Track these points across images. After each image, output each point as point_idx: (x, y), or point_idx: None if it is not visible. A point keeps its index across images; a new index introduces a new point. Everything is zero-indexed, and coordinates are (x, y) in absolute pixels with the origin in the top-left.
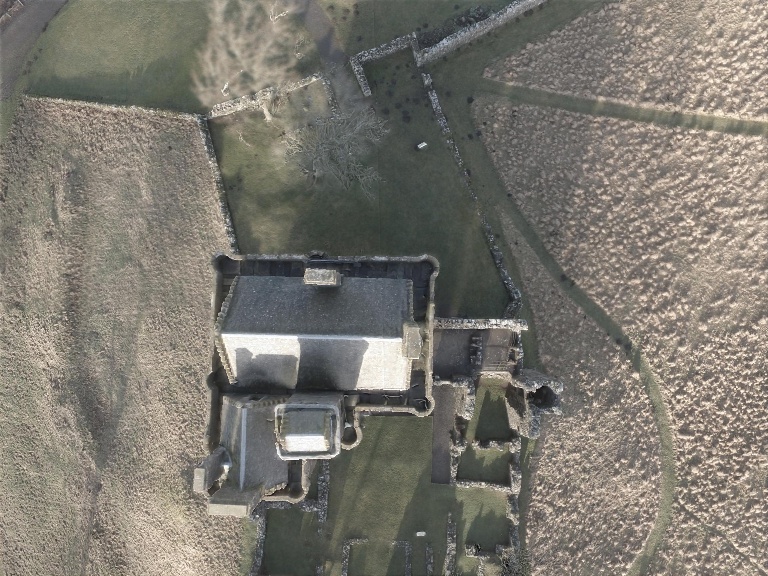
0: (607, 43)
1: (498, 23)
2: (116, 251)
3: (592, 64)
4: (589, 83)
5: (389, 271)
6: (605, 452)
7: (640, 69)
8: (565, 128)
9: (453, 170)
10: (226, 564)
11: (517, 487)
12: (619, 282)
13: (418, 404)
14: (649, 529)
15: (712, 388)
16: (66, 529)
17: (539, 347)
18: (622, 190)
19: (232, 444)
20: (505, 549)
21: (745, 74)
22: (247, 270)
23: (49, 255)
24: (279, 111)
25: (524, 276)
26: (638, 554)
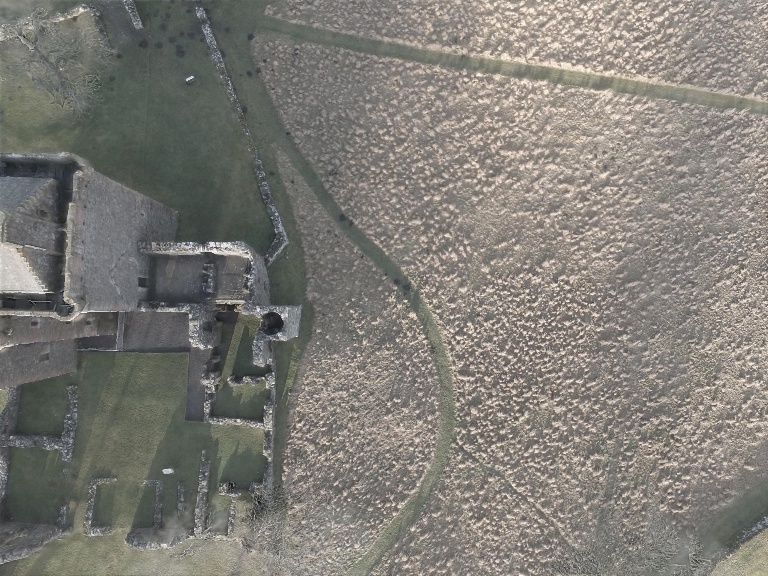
0: None
1: None
2: None
3: (378, 5)
4: (375, 24)
5: (38, 172)
6: (376, 391)
7: (427, 11)
8: (349, 68)
9: (225, 106)
10: None
11: (268, 422)
12: (399, 222)
13: (66, 310)
14: (424, 469)
15: (494, 329)
16: None
17: (308, 285)
18: (405, 131)
19: None
20: (257, 486)
21: (533, 19)
22: None
23: None
24: None
25: (298, 214)
26: (412, 494)
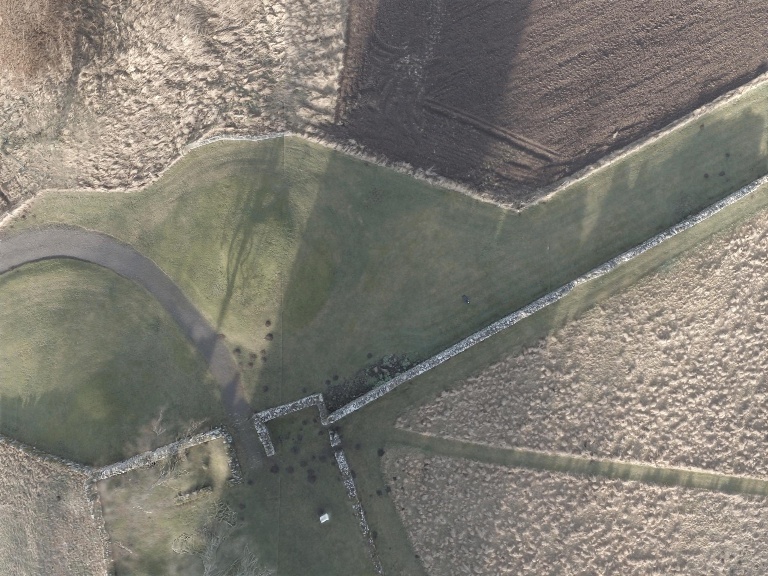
0: (525, 388)
1: None
2: None
3: (509, 411)
4: (505, 432)
5: None
6: None
7: (558, 416)
8: (478, 480)
9: (357, 539)
10: None
11: None
12: None
13: None
14: None
15: None
16: None
17: None
18: (534, 547)
19: None
20: None
21: (664, 420)
22: None
23: None
24: (176, 469)
25: None
26: None
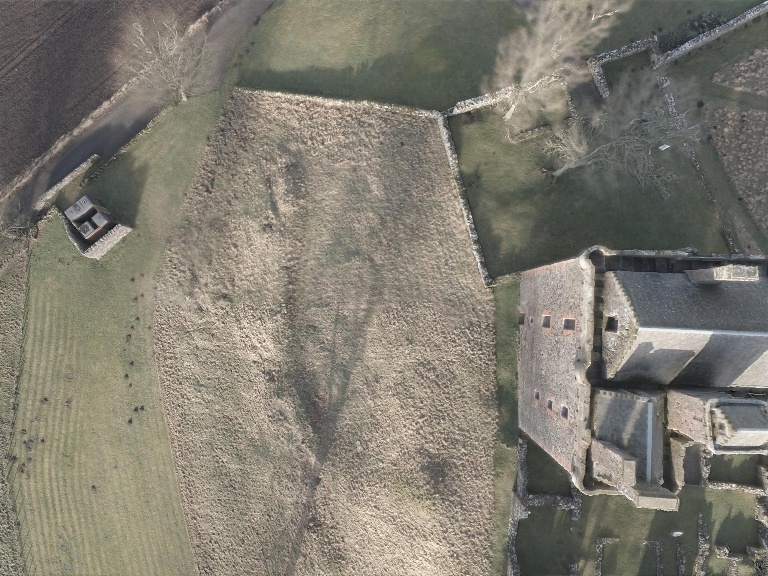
0: None
1: (730, 29)
2: (339, 245)
3: None
4: None
5: None
6: None
7: None
8: None
9: (690, 173)
10: (475, 560)
11: None
12: None
13: None
14: None
15: None
16: (270, 523)
17: None
18: None
19: (624, 438)
20: (758, 551)
21: None
22: (613, 265)
23: (267, 247)
24: (516, 110)
25: None
26: None
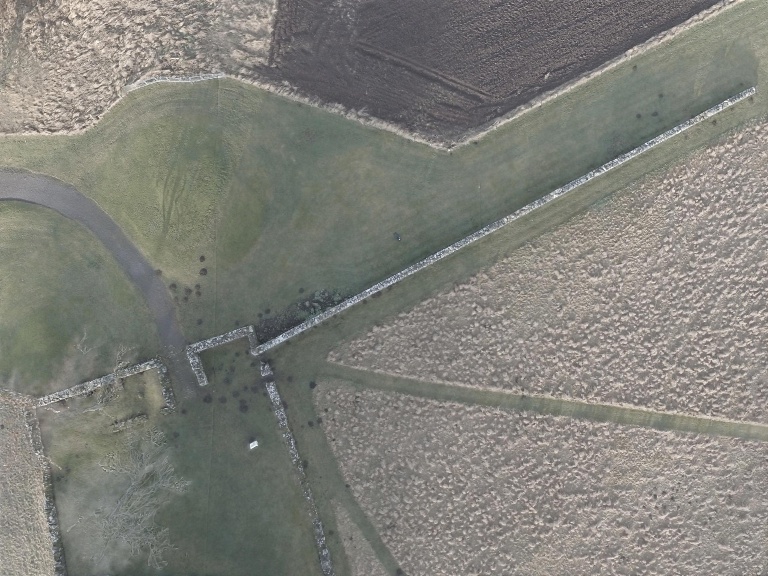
0: (457, 324)
1: None
2: None
3: (440, 347)
4: (436, 367)
5: None
6: None
7: (489, 351)
8: (409, 413)
9: (287, 466)
10: None
11: None
12: (456, 575)
13: None
14: None
15: None
16: None
17: None
18: (464, 479)
19: None
20: None
21: (595, 357)
22: None
23: None
24: None
25: (356, 575)
26: None
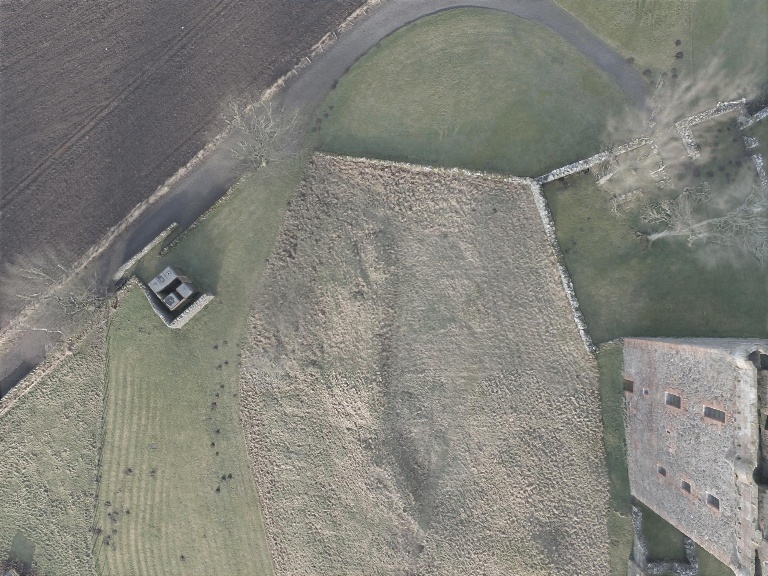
0: None
1: None
2: (433, 312)
3: None
4: None
5: None
6: None
7: None
8: None
9: None
10: None
11: None
12: None
13: None
14: None
15: None
16: None
17: None
18: None
19: None
20: None
21: None
22: None
23: (359, 315)
24: None
25: None
26: None
